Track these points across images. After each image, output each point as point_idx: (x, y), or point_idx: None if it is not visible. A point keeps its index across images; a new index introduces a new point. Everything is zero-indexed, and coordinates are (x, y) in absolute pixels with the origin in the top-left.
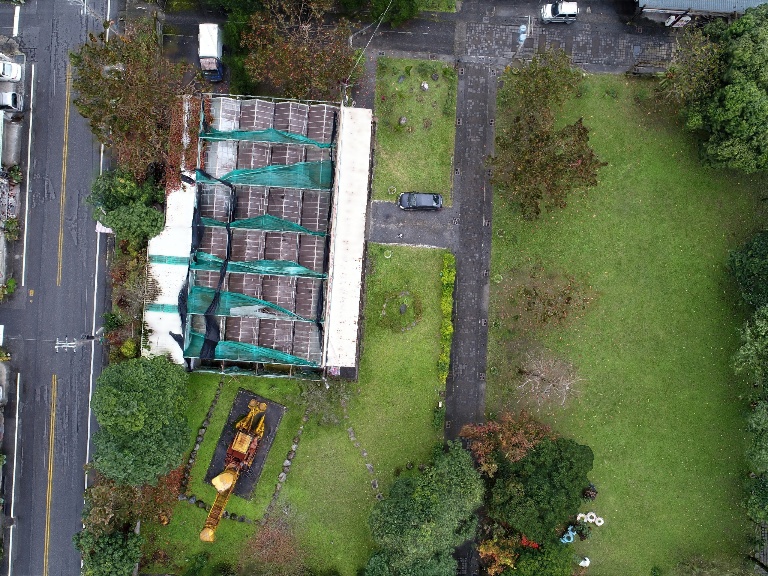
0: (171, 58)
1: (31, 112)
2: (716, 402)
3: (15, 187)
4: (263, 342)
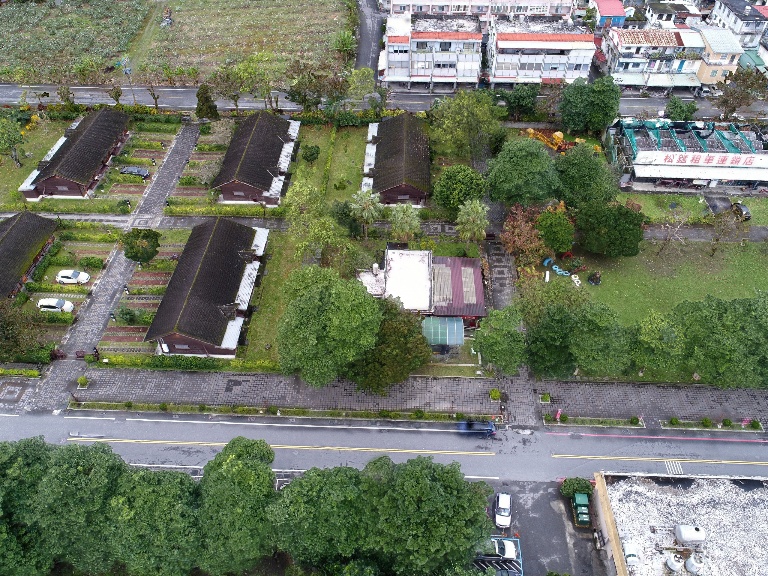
0: (757, 135)
1: (702, 100)
2: None
3: (664, 96)
4: None
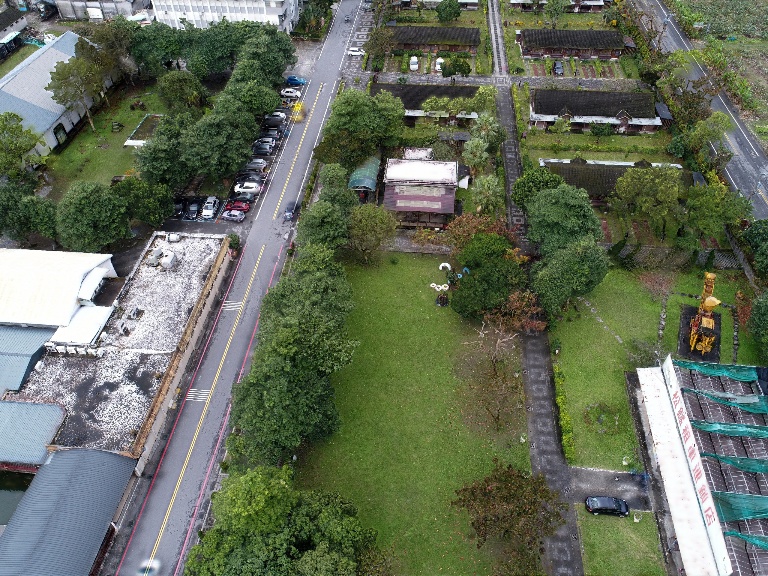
0: None
1: None
2: None
3: None
4: (719, 384)
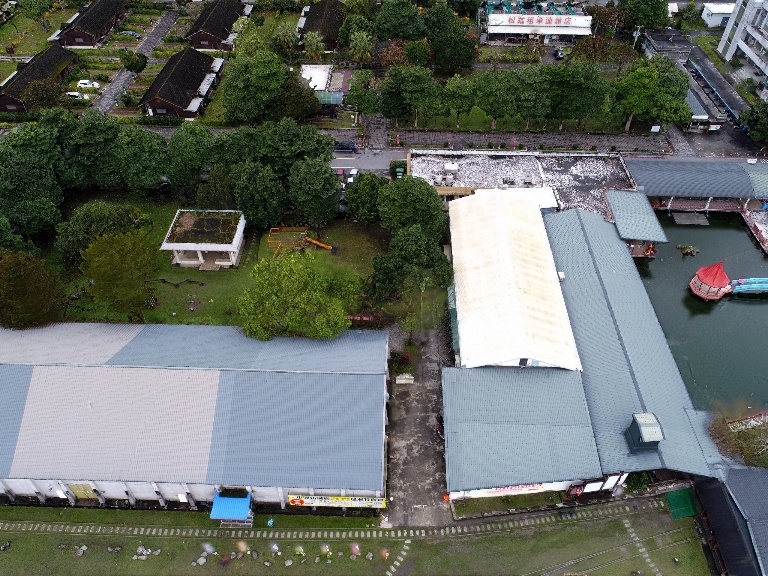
0: None
1: None
2: None
3: None
4: None
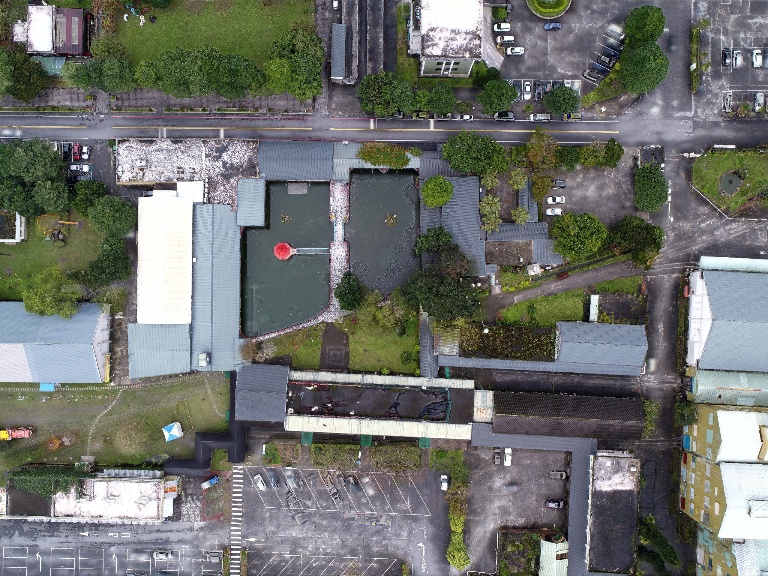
0: None
1: None
2: None
3: None
4: None
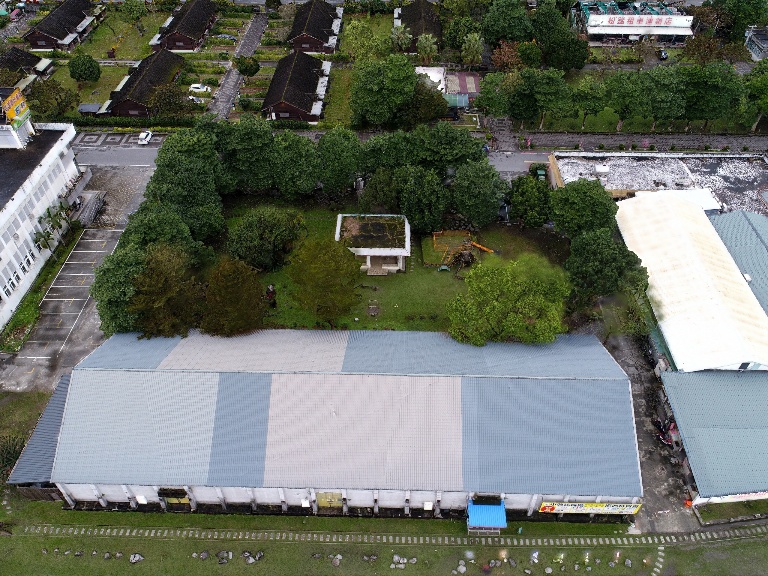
0: None
1: None
2: (614, 120)
3: None
4: None
